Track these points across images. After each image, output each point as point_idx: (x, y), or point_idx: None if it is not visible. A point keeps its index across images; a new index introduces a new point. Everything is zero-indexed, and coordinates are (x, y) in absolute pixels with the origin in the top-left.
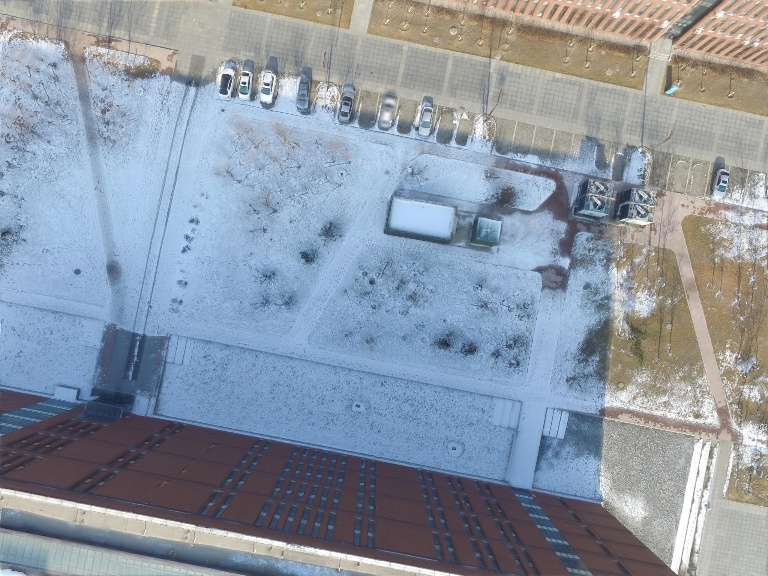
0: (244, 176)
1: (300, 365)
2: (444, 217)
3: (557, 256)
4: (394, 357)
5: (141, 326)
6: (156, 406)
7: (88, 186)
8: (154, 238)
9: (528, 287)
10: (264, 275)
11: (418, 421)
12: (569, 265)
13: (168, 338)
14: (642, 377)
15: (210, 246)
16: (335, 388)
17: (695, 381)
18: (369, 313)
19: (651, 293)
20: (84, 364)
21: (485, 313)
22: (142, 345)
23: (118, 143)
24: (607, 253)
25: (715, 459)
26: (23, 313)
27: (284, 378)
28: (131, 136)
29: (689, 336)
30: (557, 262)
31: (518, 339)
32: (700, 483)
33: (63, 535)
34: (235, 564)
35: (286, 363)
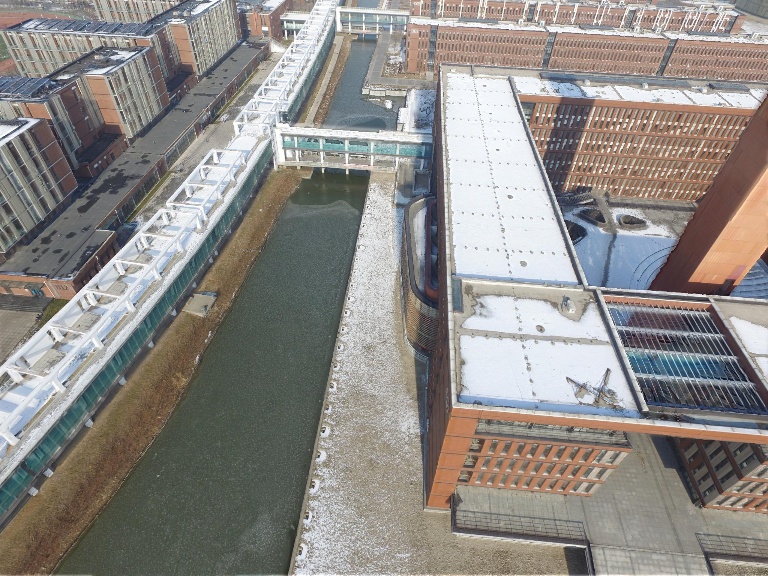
0: None
1: None
2: None
3: None
4: None
5: None
6: None
7: None
8: None
9: None
10: None
11: None
12: None
13: None
14: None
15: None
16: None
17: None
18: None
19: None
20: None
21: None
22: None
23: None
24: None
25: None
26: None
27: None
28: None
29: None
30: None
31: None
32: None
33: None
34: None
35: None
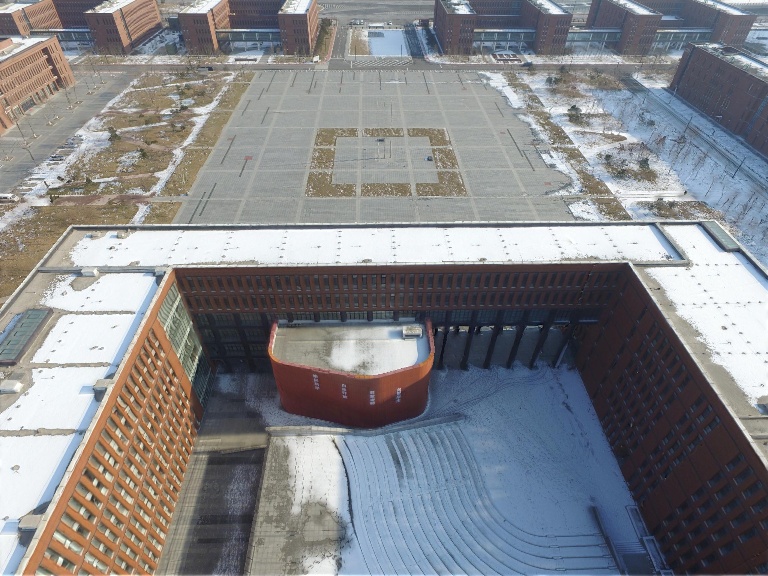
0: None
1: None
2: None
3: None
4: None
5: None
6: None
7: None
8: None
9: None
10: None
11: None
12: None
13: None
14: None
15: None
16: None
17: None
18: None
19: None
20: None
21: None
22: None
23: None
24: None
25: None
26: None
27: None
28: None
29: None
30: None
31: None
32: None
33: None
34: None
35: None
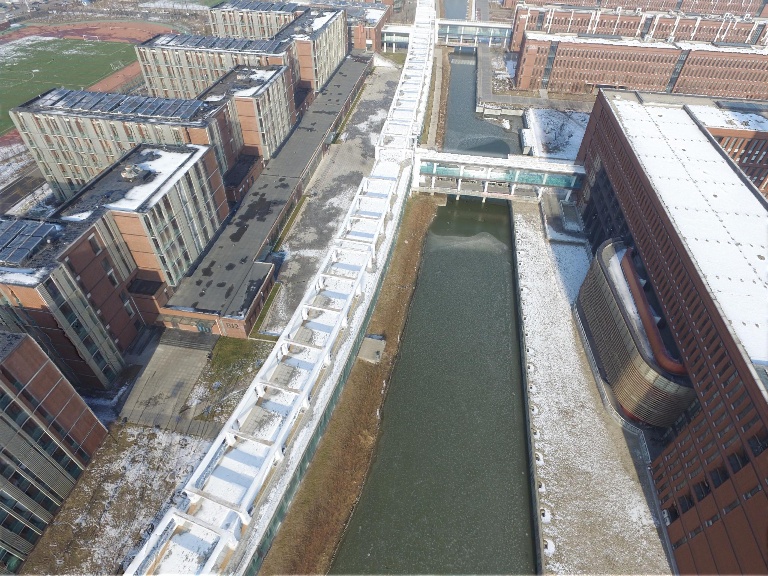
0: None
1: None
2: None
3: None
4: None
5: None
6: None
7: None
8: None
9: None
10: None
11: None
12: None
13: None
14: None
15: None
16: None
17: None
18: None
19: None
20: None
21: None
22: None
23: None
24: None
25: None
26: None
27: None
28: None
29: None
30: None
31: None
32: None
33: None
34: None
35: None
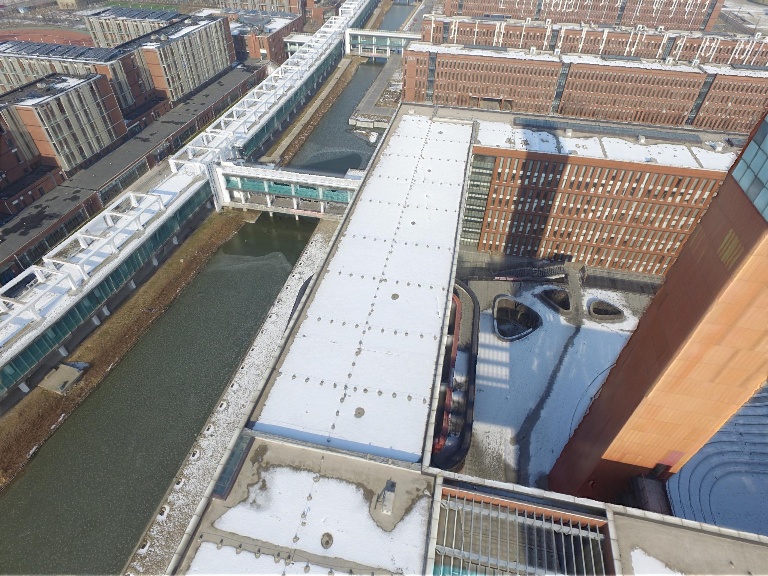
0: None
1: None
2: None
3: None
4: None
5: None
6: None
7: None
8: None
9: None
10: None
11: None
12: None
13: None
14: None
15: None
16: None
17: None
18: None
19: None
20: None
21: None
22: None
23: None
24: None
25: None
26: None
27: None
28: None
29: None
30: None
31: None
32: None
33: None
34: None
35: None
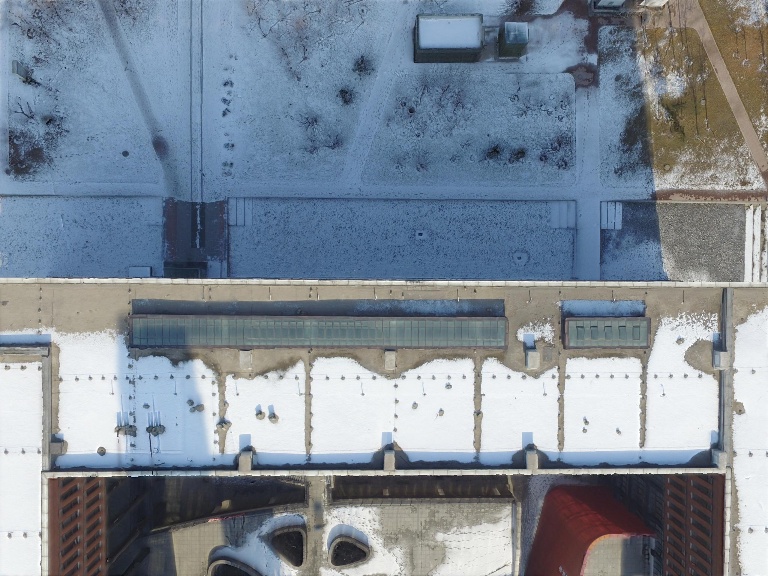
0: (268, 30)
1: (358, 205)
2: (471, 29)
3: (585, 54)
4: (447, 180)
5: (198, 195)
6: (228, 270)
7: (118, 68)
8: (193, 107)
9: (562, 89)
10: (307, 120)
11: (480, 238)
12: (597, 61)
13: (226, 202)
14: (686, 156)
15: (249, 105)
16: (396, 221)
17: (736, 150)
18: (415, 142)
19: (680, 73)
20: (150, 243)
21: (526, 121)
22: (203, 213)
23: (138, 20)
24: (632, 42)
25: (767, 221)
26: (81, 204)
27: (345, 220)
28: (150, 11)
29: (723, 108)
30: (586, 60)
31: (562, 140)
32: (757, 247)
33: (195, 313)
34: (360, 312)
35: (344, 206)
